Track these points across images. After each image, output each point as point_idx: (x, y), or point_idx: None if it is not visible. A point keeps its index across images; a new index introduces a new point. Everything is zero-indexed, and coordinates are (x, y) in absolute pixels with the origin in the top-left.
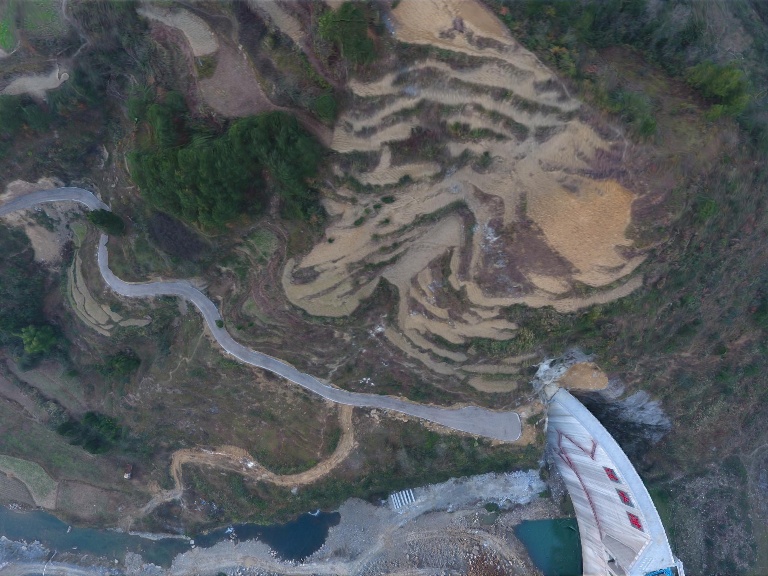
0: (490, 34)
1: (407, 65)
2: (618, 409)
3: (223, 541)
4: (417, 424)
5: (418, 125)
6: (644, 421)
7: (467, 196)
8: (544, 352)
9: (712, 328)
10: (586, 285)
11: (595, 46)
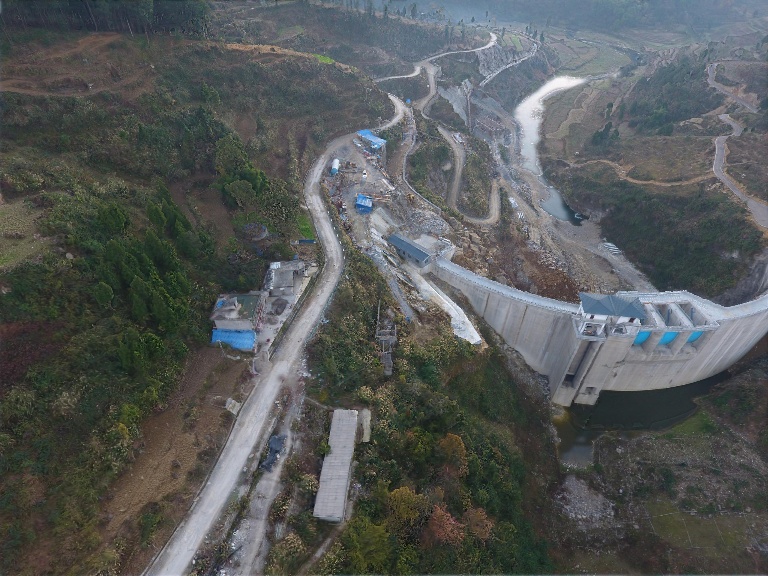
0: None
1: None
2: None
3: (544, 184)
4: None
5: None
6: None
7: None
8: None
9: None
10: None
11: None
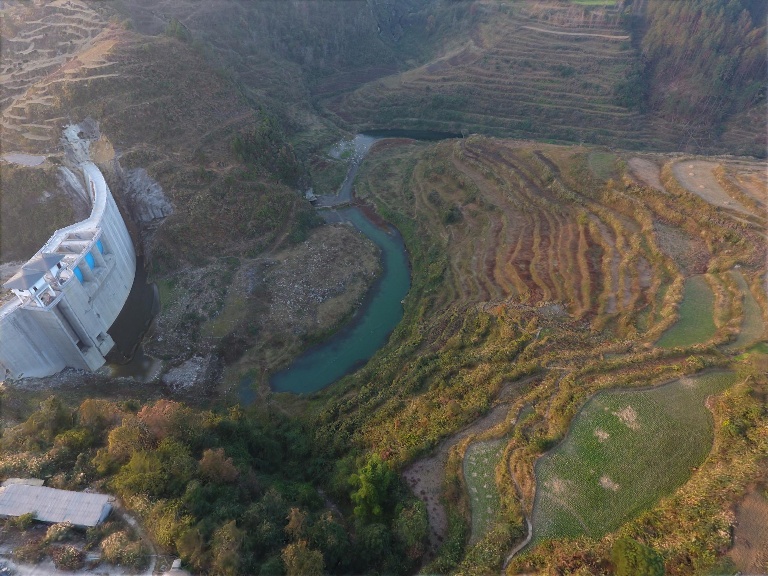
0: (78, 4)
1: (48, 15)
2: (136, 195)
3: None
4: None
5: (47, 33)
6: (152, 204)
7: (63, 62)
8: (69, 117)
9: (196, 143)
10: (84, 67)
11: (120, 12)
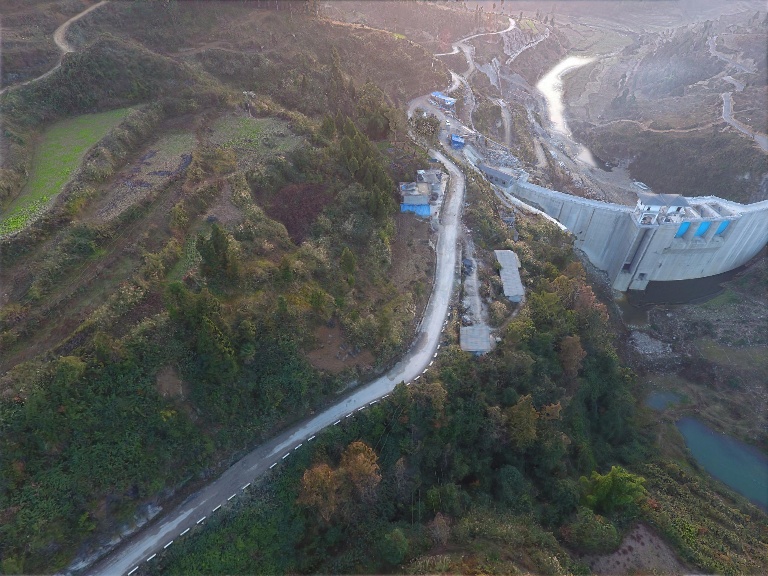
0: None
1: None
2: None
3: (575, 142)
4: (737, 133)
5: None
6: None
7: None
8: None
9: None
10: None
11: None
